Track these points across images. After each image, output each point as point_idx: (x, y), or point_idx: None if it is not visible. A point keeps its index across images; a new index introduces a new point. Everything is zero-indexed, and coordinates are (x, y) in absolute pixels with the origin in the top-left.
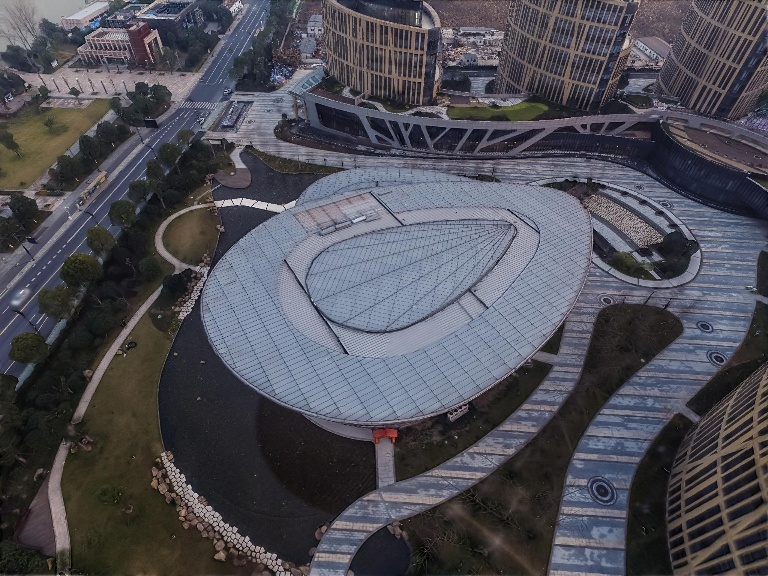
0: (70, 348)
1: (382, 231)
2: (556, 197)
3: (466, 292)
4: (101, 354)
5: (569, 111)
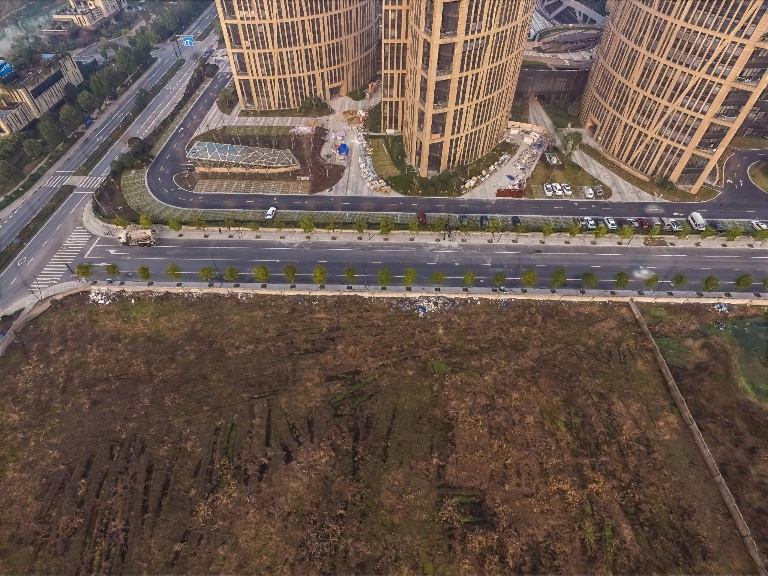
0: None
1: None
2: None
3: None
4: None
5: (590, 4)
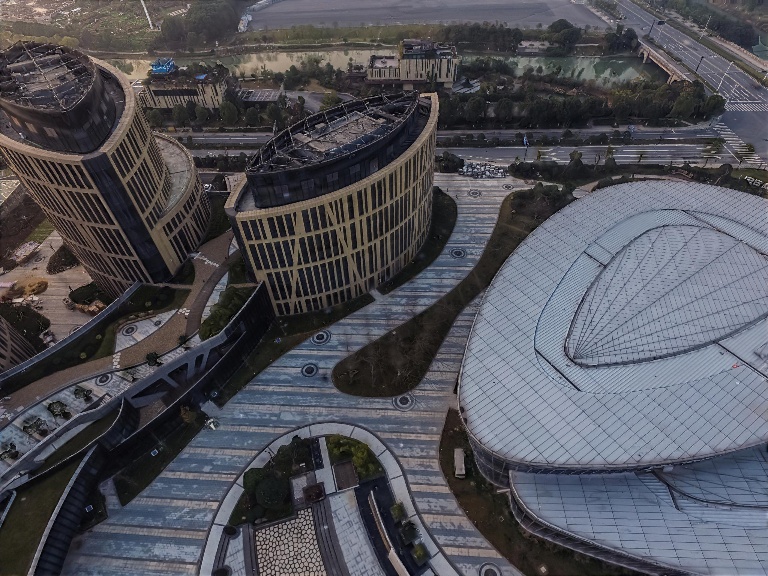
0: None
1: (737, 328)
2: (506, 431)
3: (608, 264)
4: None
5: None
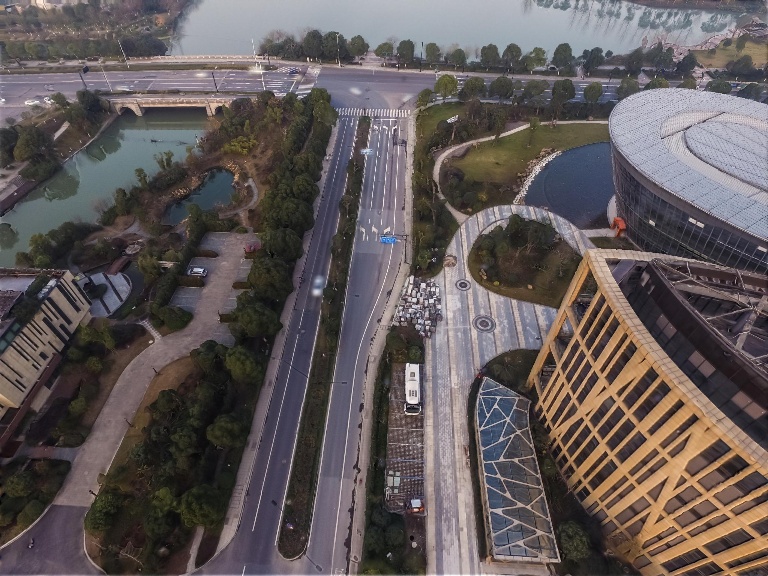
0: (602, 106)
1: None
2: None
3: None
4: (605, 120)
5: None
